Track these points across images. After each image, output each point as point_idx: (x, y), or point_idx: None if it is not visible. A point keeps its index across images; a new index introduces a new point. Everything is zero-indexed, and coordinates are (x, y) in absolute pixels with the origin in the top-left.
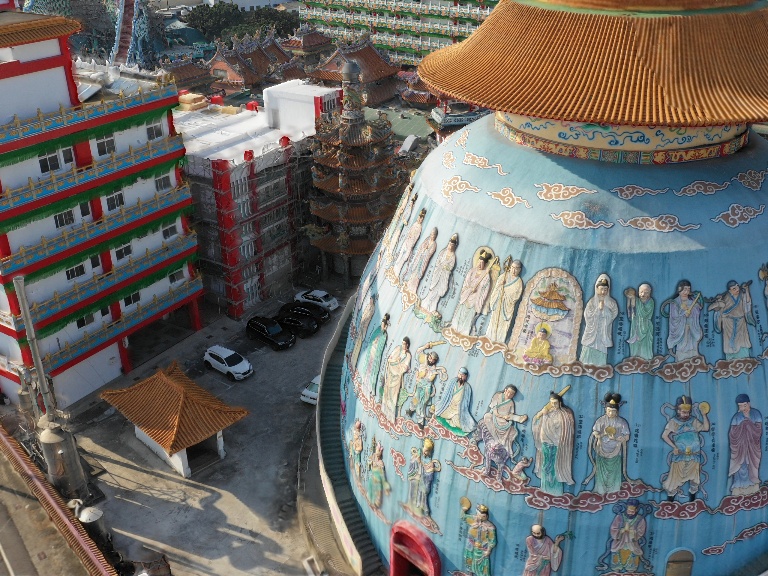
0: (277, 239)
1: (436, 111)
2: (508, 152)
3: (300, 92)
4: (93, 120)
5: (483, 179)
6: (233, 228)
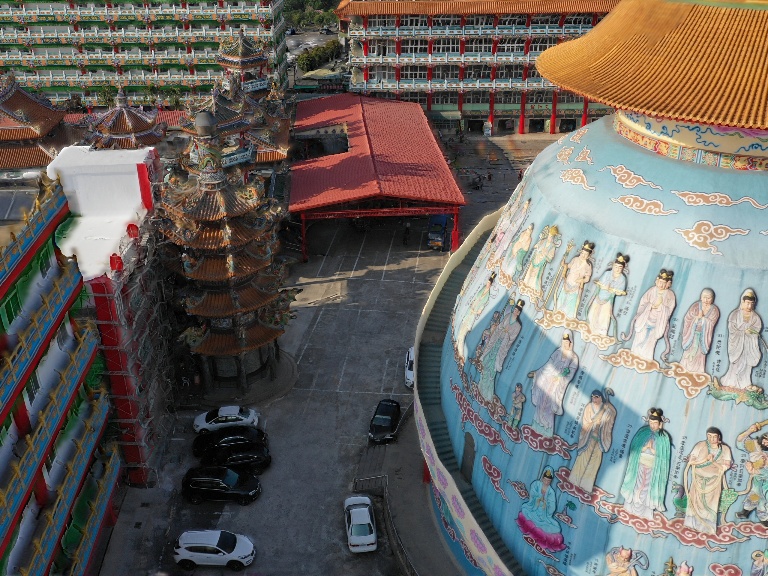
0: (147, 361)
1: (196, 154)
2: (746, 181)
3: (107, 162)
4: (14, 271)
5: (743, 218)
6: (128, 366)
